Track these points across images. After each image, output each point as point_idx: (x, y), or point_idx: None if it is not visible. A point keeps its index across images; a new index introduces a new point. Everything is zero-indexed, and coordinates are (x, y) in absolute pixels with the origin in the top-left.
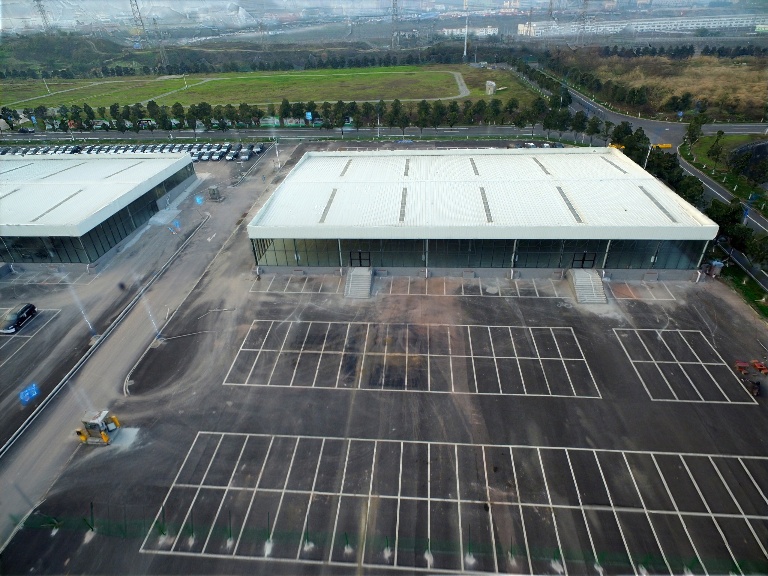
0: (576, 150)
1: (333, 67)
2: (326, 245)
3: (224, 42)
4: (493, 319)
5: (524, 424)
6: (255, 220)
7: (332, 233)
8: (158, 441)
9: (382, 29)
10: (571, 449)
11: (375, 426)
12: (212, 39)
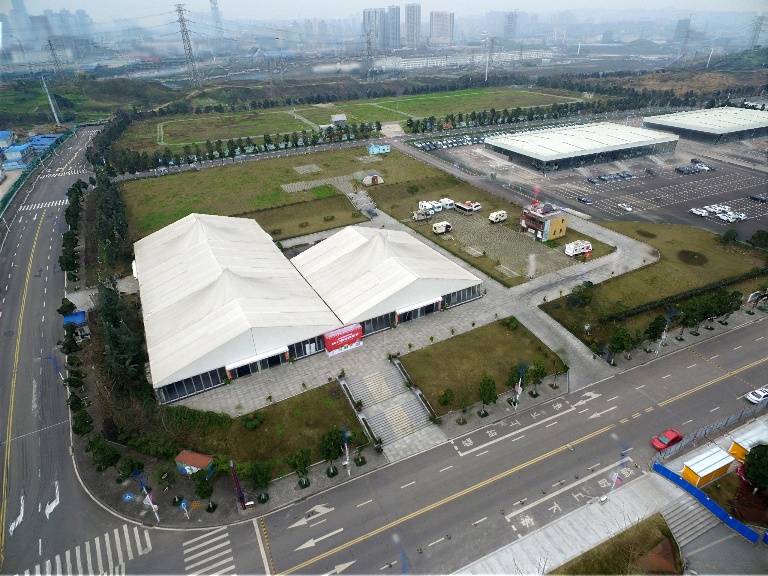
0: (718, 109)
1: (424, 92)
2: None
3: (236, 80)
4: None
5: None
6: None
7: None
8: None
9: (360, 66)
10: None
11: None
12: (218, 78)
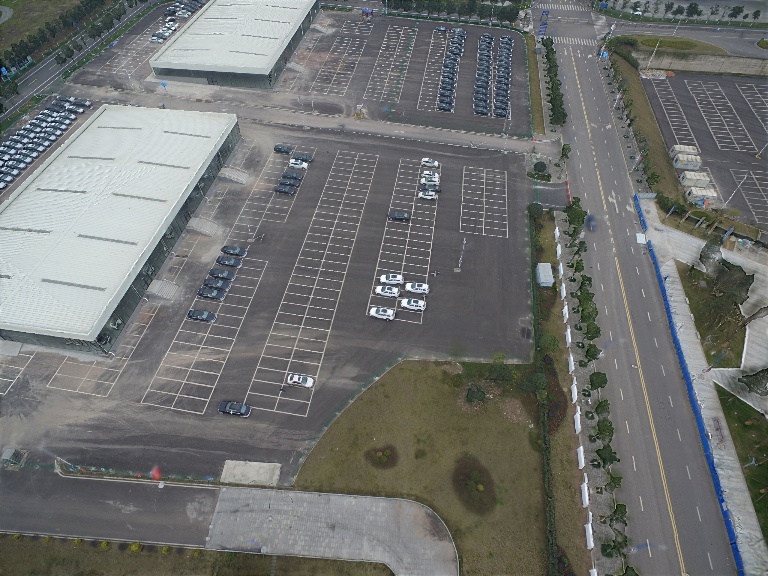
0: None
1: None
2: (279, 61)
3: None
4: (328, 48)
5: None
6: None
7: (279, 53)
8: (365, 105)
9: None
10: None
11: (368, 71)
12: None
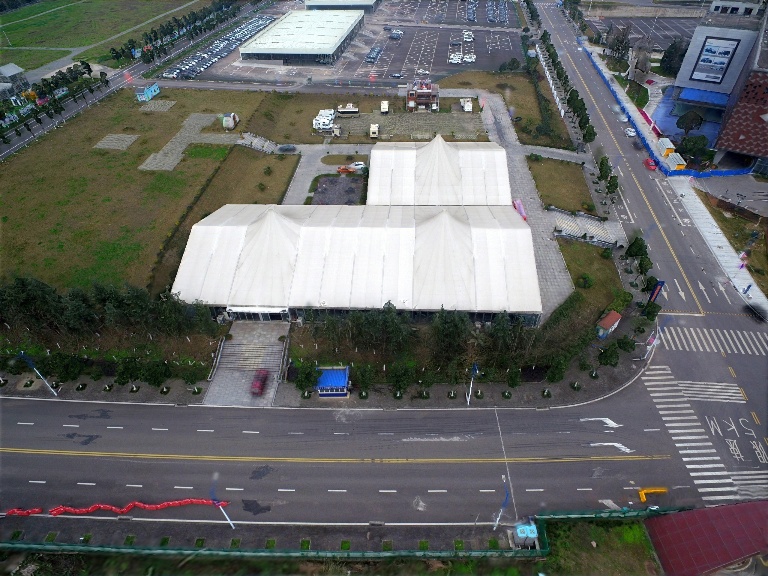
0: None
1: None
2: None
3: None
4: None
5: (425, 6)
6: (367, 1)
7: None
8: None
9: None
10: (429, 5)
11: None
12: None
